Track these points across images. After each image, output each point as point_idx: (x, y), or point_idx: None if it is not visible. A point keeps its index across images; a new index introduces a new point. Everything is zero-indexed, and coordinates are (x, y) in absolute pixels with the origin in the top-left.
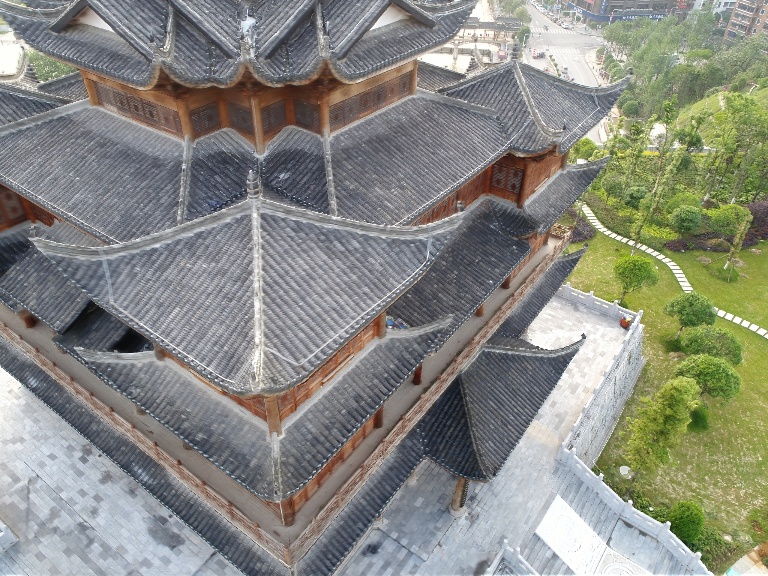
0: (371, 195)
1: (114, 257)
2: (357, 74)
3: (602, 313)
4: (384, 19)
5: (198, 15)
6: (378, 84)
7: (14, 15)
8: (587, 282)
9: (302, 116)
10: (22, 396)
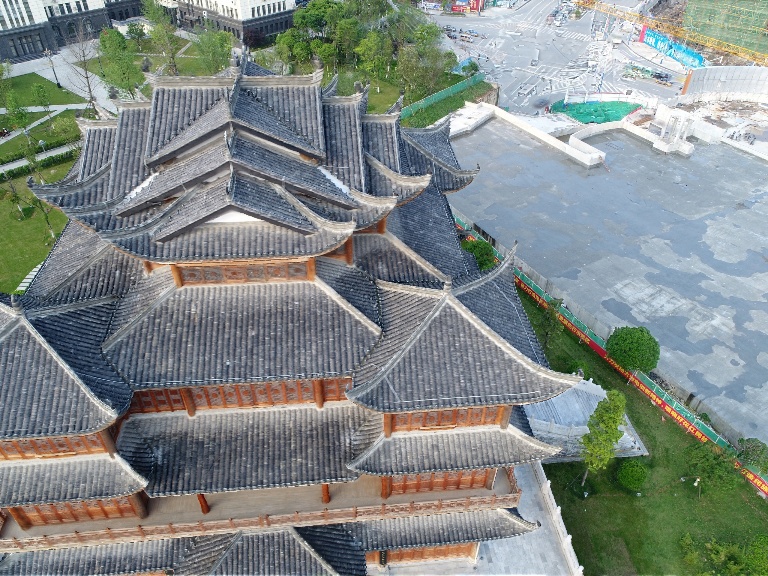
0: None
1: None
2: None
3: None
4: None
5: None
6: None
7: None
8: None
9: None
10: (483, 545)
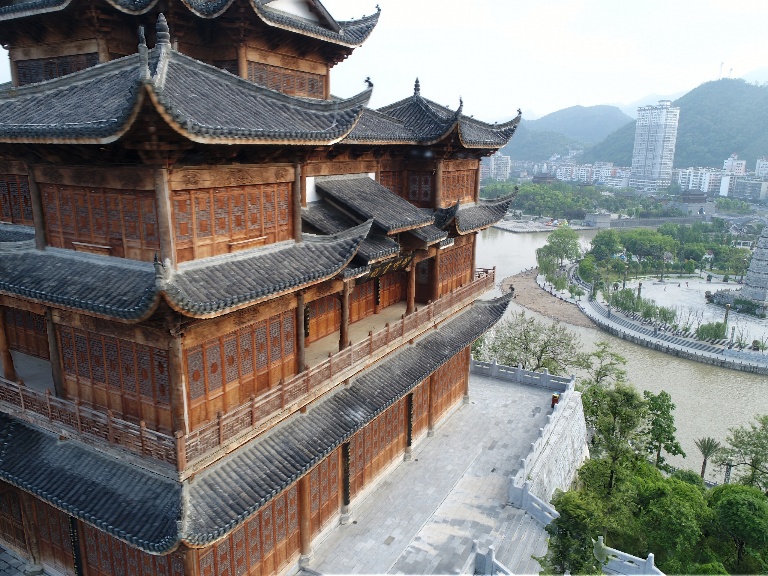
0: None
1: None
2: None
3: None
4: None
5: None
6: None
7: None
8: None
9: None
10: None
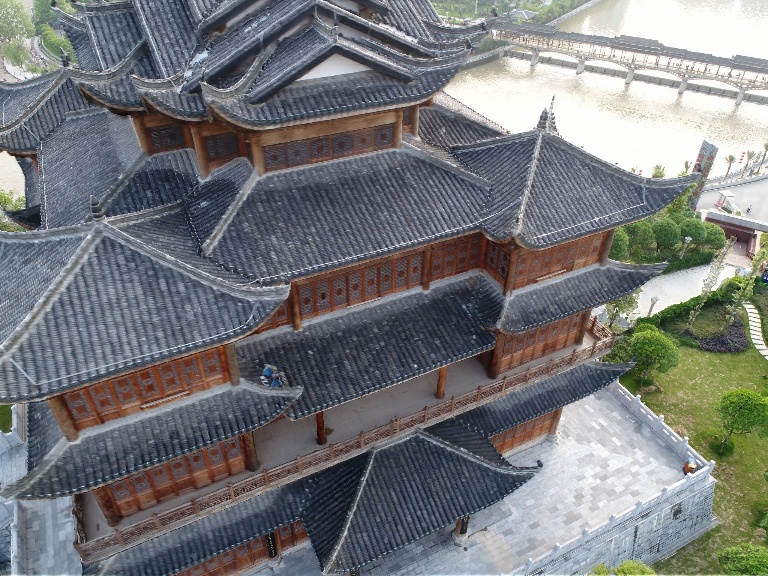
0: (261, 242)
1: (11, 242)
2: (263, 121)
3: (668, 446)
4: (338, 68)
5: (154, 44)
6: (338, 132)
7: (71, 25)
8: (696, 403)
9: (249, 150)
10: None
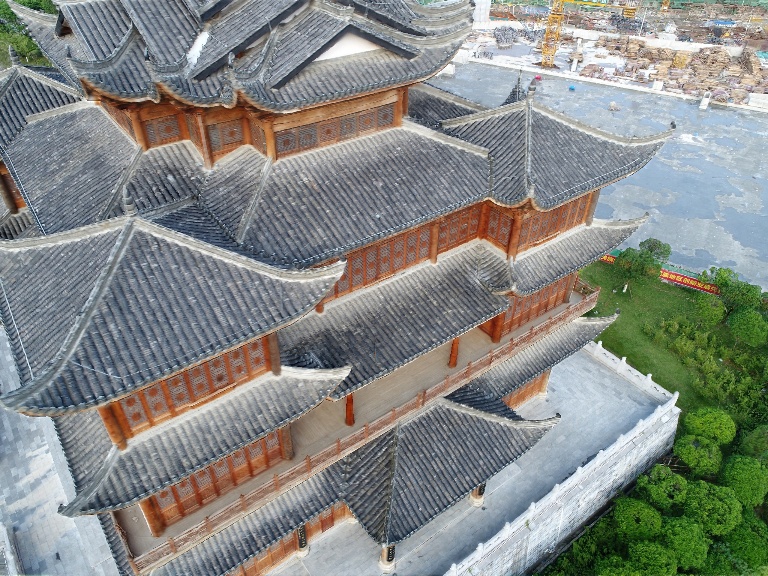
0: None
1: None
2: None
3: None
4: None
5: None
6: None
7: None
8: None
9: None
10: None
